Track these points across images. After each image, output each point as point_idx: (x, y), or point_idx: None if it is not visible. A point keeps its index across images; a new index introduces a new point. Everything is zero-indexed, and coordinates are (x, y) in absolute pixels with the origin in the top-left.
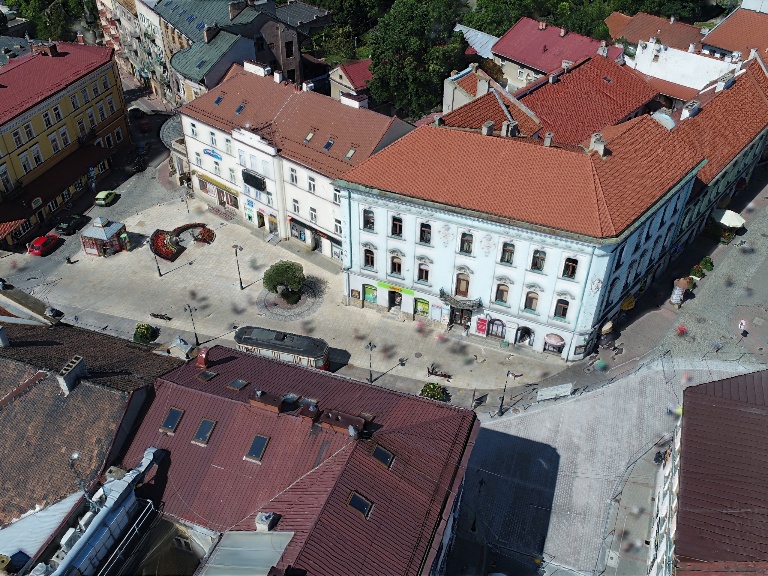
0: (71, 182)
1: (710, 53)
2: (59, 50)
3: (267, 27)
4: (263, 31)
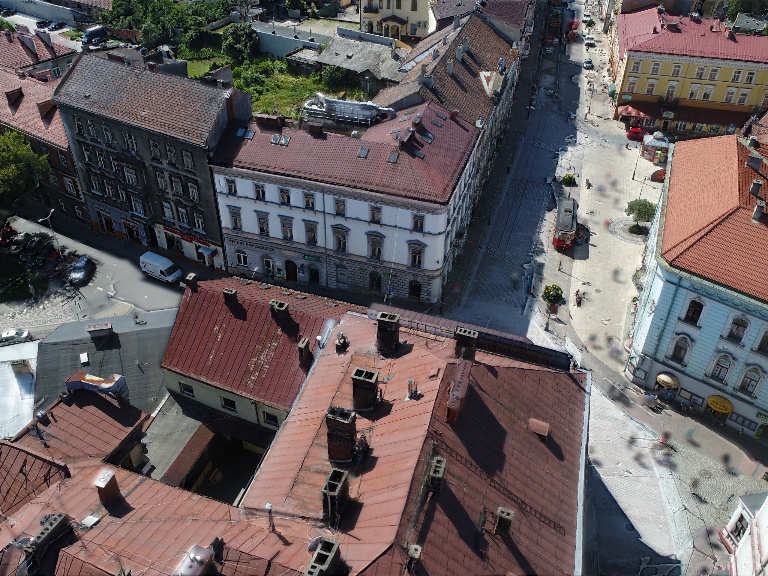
0: (708, 122)
1: None
2: None
3: None
4: None
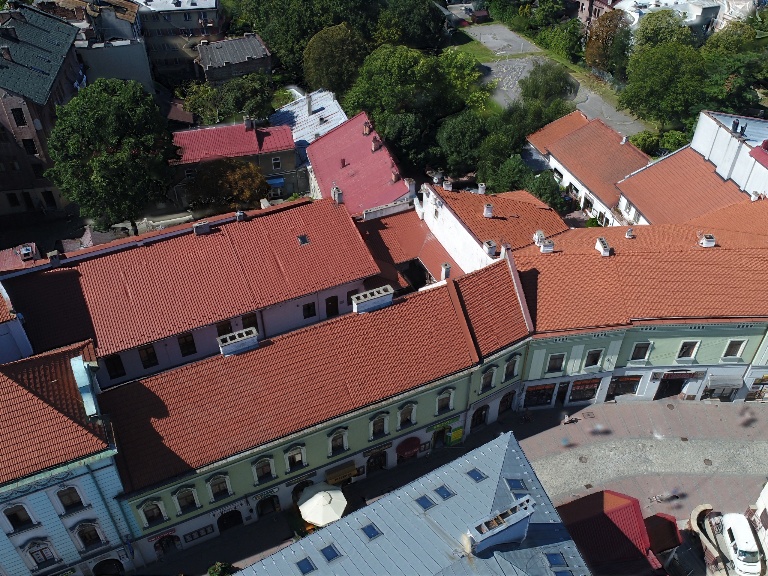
0: None
1: (628, 203)
2: None
3: None
4: None
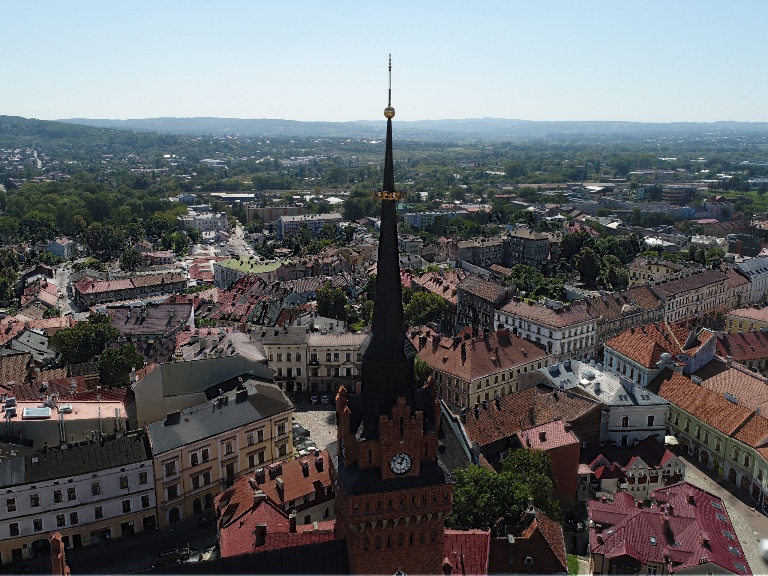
0: None
1: None
2: None
3: None
4: None
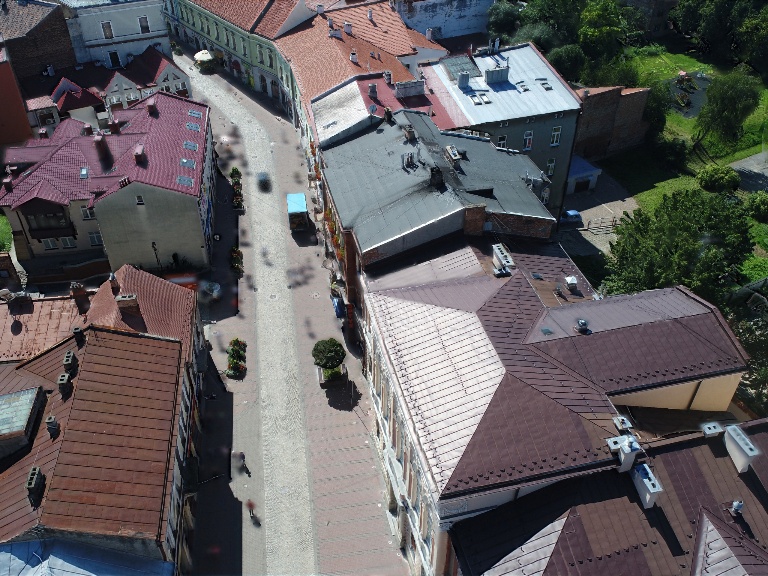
0: None
1: None
2: None
3: None
4: None
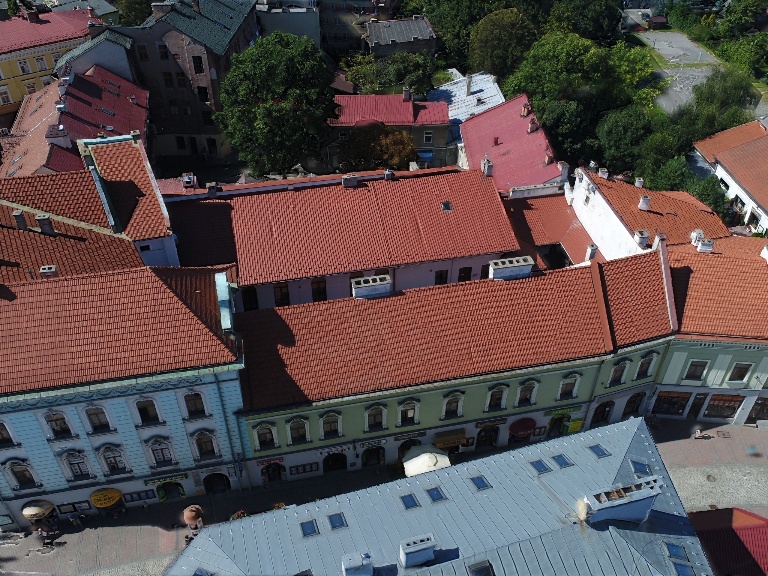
0: None
1: None
2: (44, 17)
3: (170, 36)
4: (166, 39)
